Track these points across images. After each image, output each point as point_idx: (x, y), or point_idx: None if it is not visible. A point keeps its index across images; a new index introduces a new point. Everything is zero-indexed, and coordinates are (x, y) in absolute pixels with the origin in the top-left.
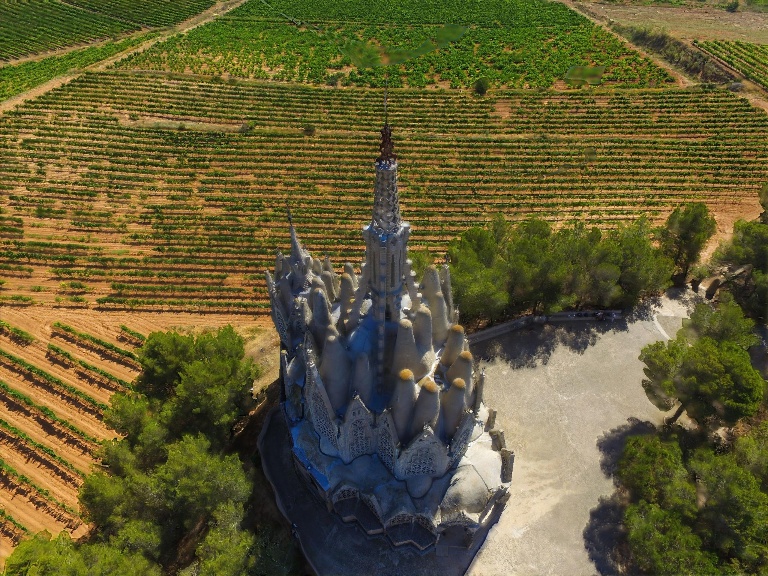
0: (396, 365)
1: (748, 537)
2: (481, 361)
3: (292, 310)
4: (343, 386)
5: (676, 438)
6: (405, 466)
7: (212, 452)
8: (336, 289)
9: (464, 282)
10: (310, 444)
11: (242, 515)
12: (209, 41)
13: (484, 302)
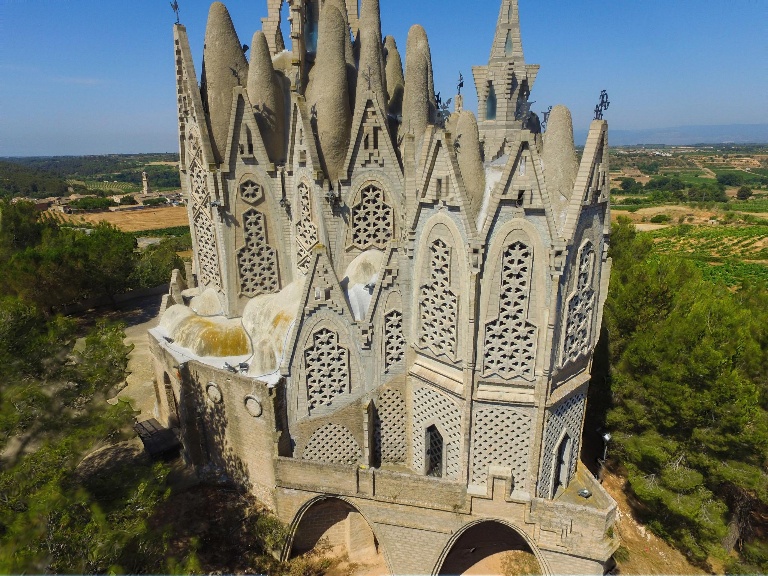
0: None
1: None
2: None
3: None
4: None
5: None
6: None
7: None
8: None
9: None
10: None
11: None
12: None
13: None
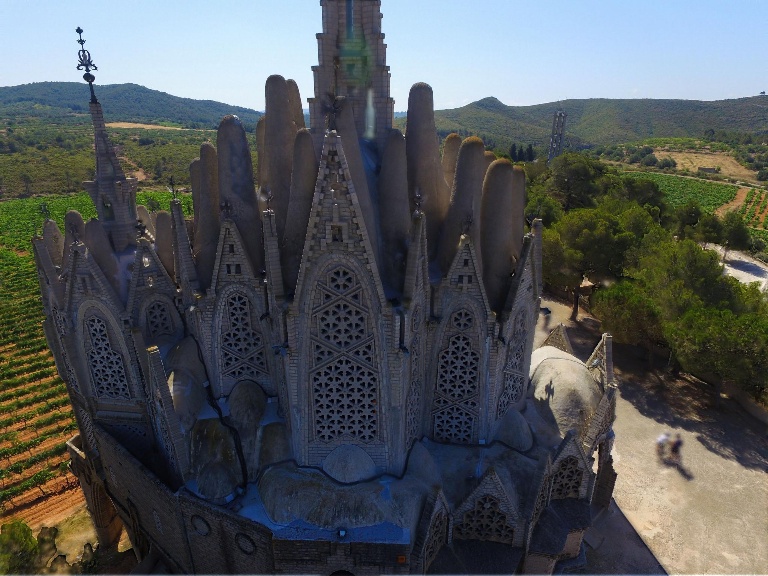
0: (422, 188)
1: (740, 290)
2: None
3: (137, 271)
4: (374, 232)
5: (615, 284)
6: (498, 387)
7: None
8: None
9: None
10: (311, 490)
11: None
12: None
13: None
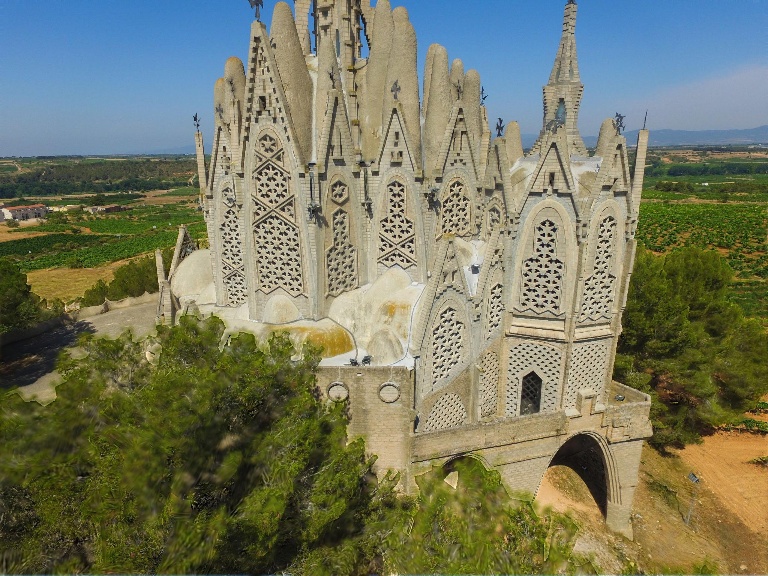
0: None
1: None
2: None
3: None
4: None
5: None
6: None
7: None
8: (491, 169)
9: (200, 321)
10: None
11: None
12: None
13: None
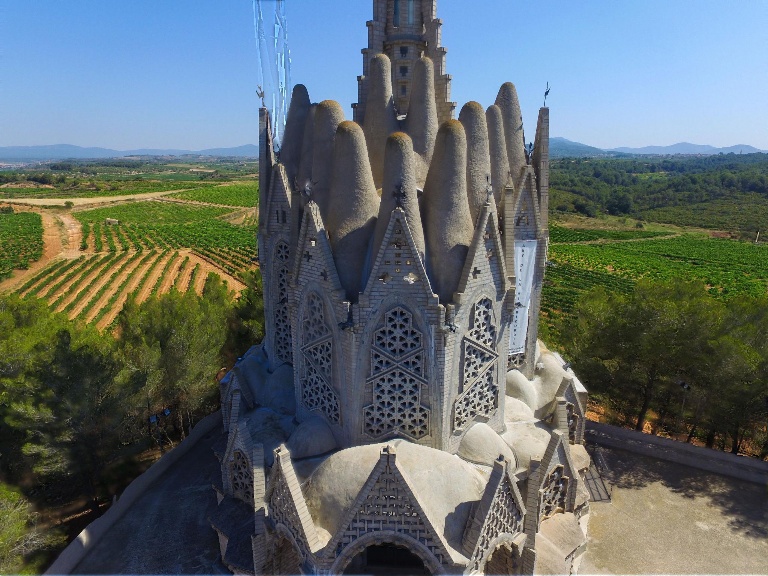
0: None
1: None
2: (656, 483)
3: None
4: None
5: None
6: (299, 363)
7: (224, 356)
8: None
9: (650, 289)
10: None
11: (155, 377)
12: (570, 249)
13: (691, 349)
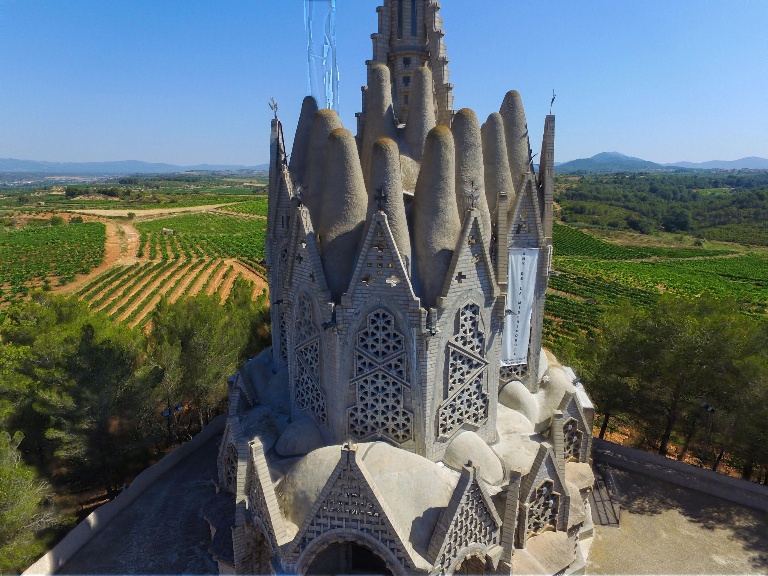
0: None
1: None
2: (673, 511)
3: None
4: None
5: None
6: (293, 363)
7: (245, 359)
8: None
9: (671, 303)
10: None
11: (175, 374)
12: (618, 266)
13: (714, 369)
